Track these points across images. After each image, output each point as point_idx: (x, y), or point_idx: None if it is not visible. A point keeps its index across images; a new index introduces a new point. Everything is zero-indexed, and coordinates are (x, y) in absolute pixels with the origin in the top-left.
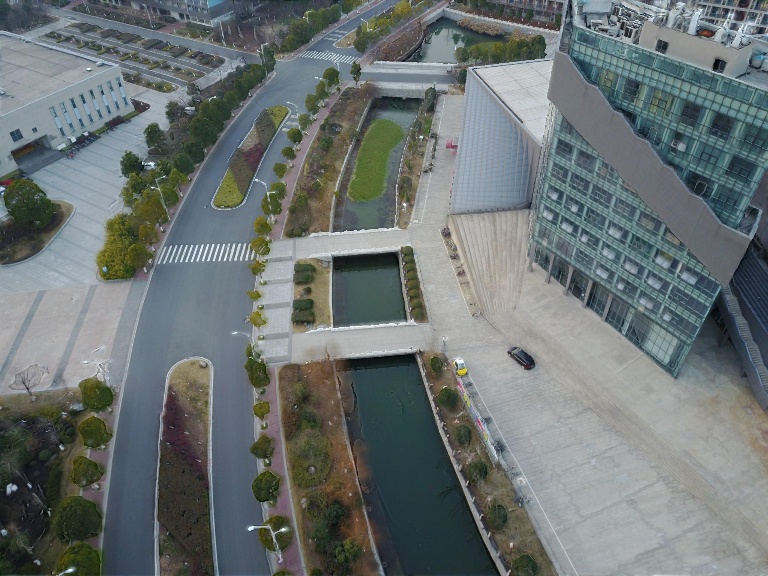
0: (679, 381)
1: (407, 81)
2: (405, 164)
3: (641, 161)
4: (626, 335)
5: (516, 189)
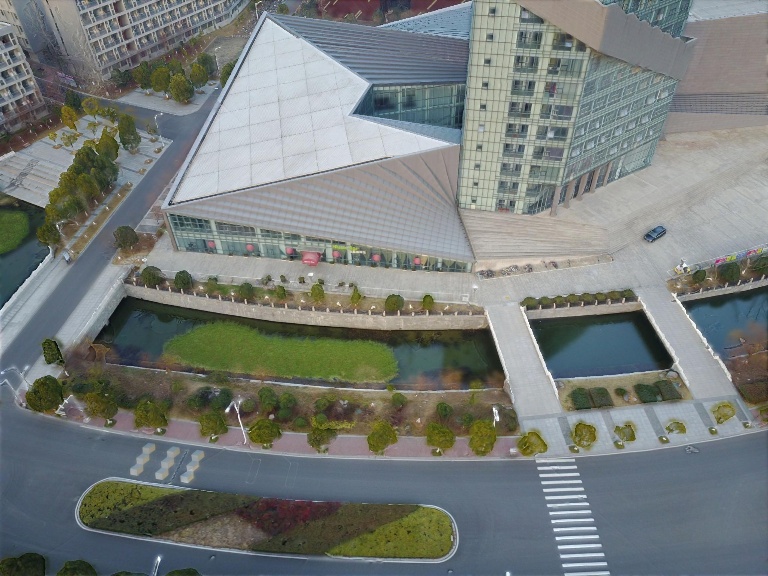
0: (652, 164)
1: (70, 309)
2: (354, 301)
3: (654, 42)
4: (619, 177)
5: (445, 203)
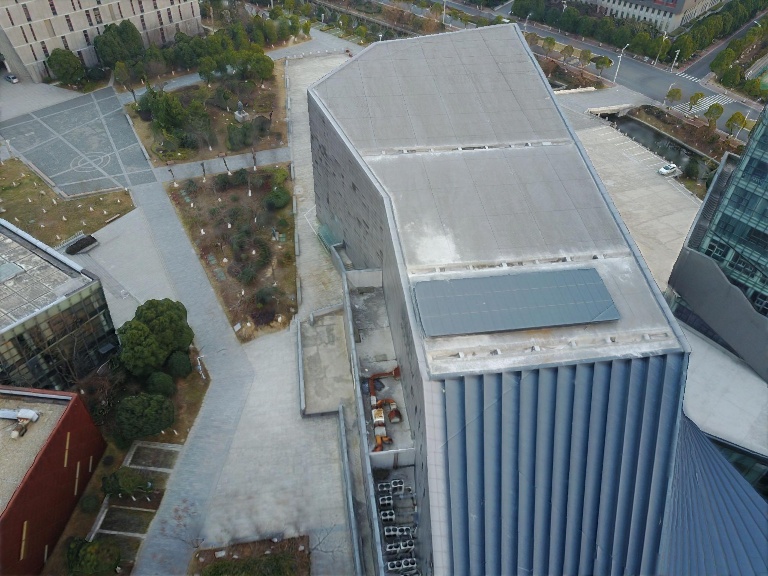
0: None
1: None
2: None
3: None
4: None
5: None
